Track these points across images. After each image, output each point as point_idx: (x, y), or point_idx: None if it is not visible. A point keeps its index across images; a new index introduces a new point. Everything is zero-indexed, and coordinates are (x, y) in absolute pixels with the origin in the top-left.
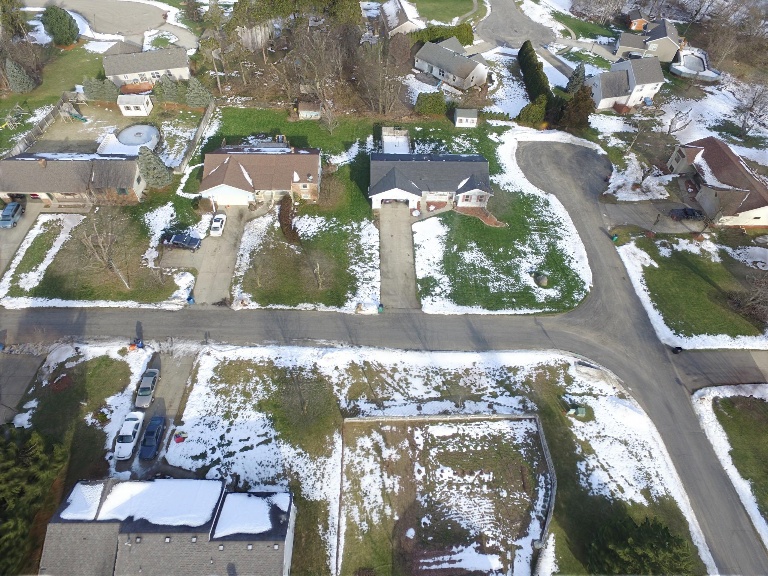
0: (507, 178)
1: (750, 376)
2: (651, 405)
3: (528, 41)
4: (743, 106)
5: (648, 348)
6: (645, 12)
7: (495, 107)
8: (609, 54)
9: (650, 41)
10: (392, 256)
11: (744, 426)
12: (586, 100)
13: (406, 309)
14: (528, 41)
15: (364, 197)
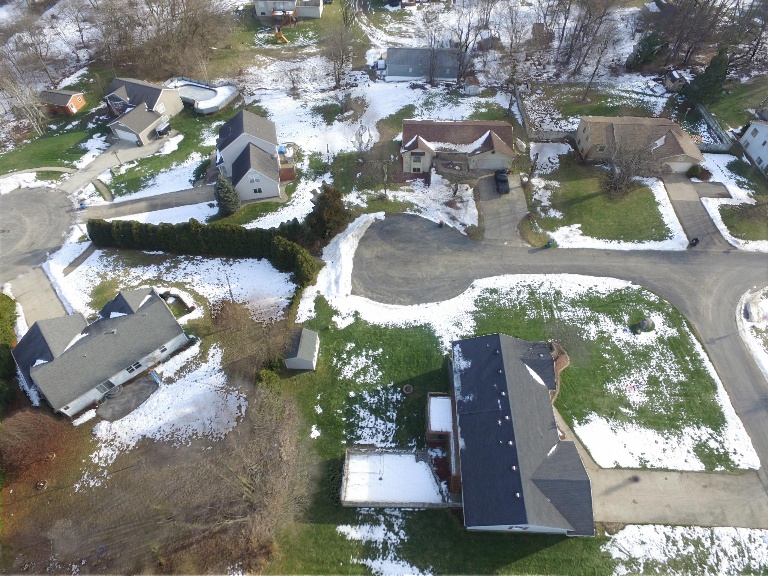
0: (443, 323)
1: (698, 208)
2: (765, 278)
3: (92, 221)
4: (287, 91)
5: (698, 261)
6: (38, 89)
7: (255, 305)
8: (137, 150)
9: (154, 106)
10: (678, 505)
11: (751, 228)
12: (338, 196)
13: (767, 491)
14: (92, 221)
15: (546, 550)
